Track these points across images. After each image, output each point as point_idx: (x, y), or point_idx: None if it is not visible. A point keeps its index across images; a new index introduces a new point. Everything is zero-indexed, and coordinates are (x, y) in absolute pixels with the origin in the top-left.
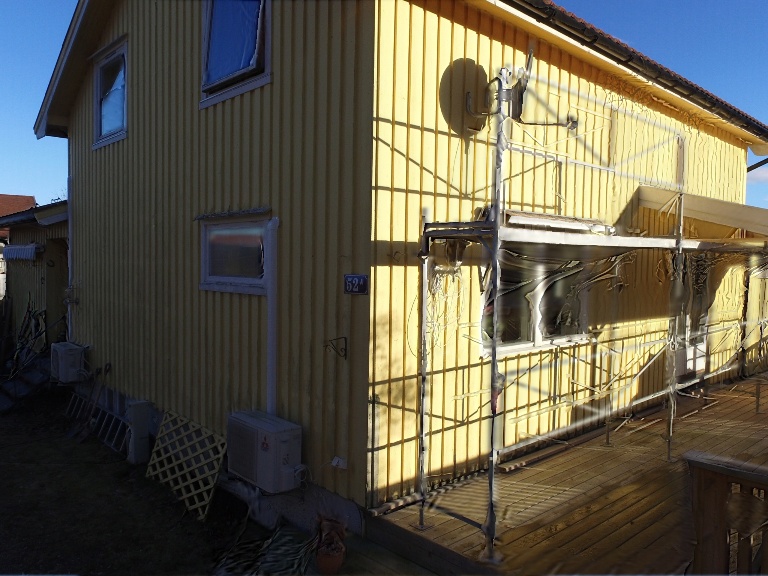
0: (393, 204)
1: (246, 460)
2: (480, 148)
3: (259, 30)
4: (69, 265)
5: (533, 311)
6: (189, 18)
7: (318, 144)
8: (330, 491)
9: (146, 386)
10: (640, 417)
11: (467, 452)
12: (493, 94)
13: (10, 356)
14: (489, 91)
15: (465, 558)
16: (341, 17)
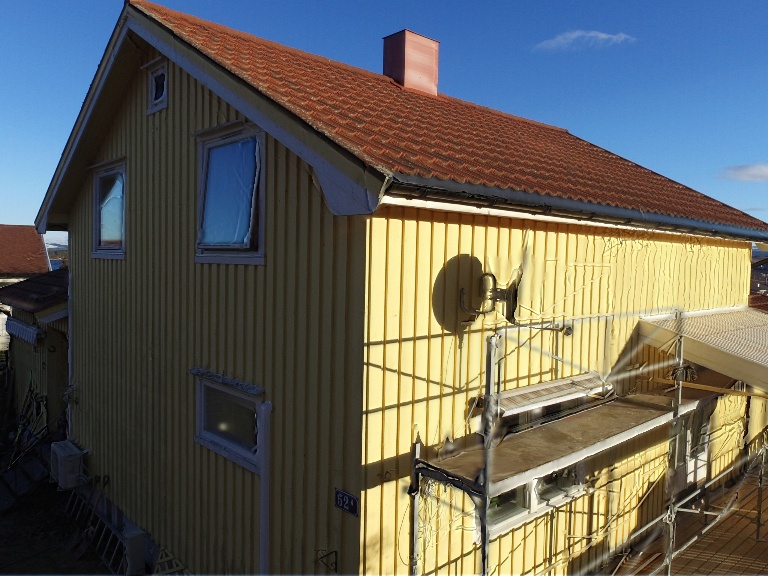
0: (384, 422)
1: None
2: (474, 338)
3: (253, 210)
4: (69, 362)
5: None
6: (185, 167)
7: (310, 346)
8: None
9: (143, 514)
10: (638, 551)
11: None
12: (488, 281)
13: (13, 427)
14: (484, 280)
15: None
16: (333, 230)
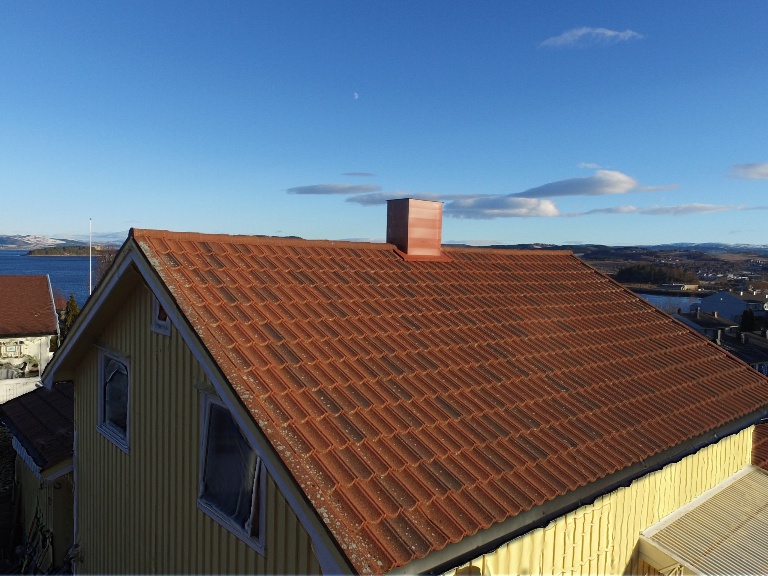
0: None
1: None
2: None
3: (254, 499)
4: (74, 518)
5: None
6: (188, 407)
7: None
8: None
9: None
10: None
11: None
12: None
13: (19, 542)
14: None
15: None
16: None
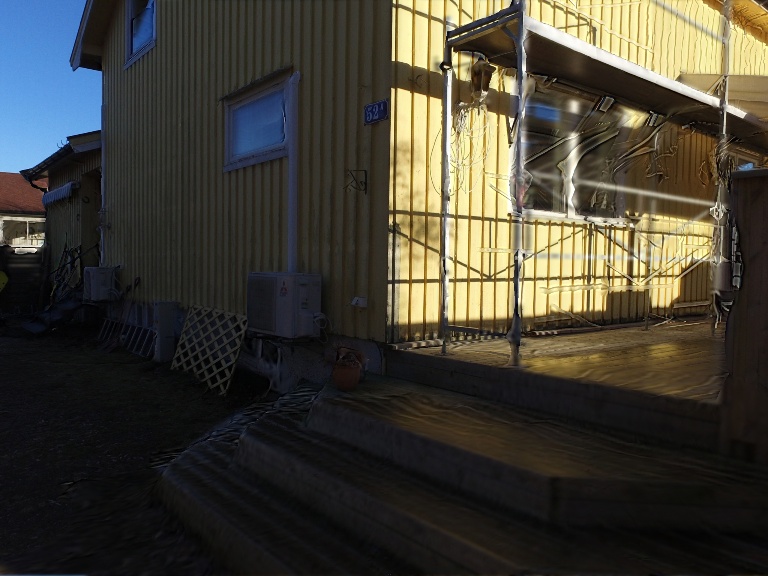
0: (415, 27)
1: (265, 311)
2: None
3: None
4: (102, 192)
5: (565, 181)
6: None
7: None
8: (350, 337)
9: (172, 288)
10: (682, 320)
11: (494, 311)
12: None
13: (48, 301)
14: None
15: (488, 367)
16: None
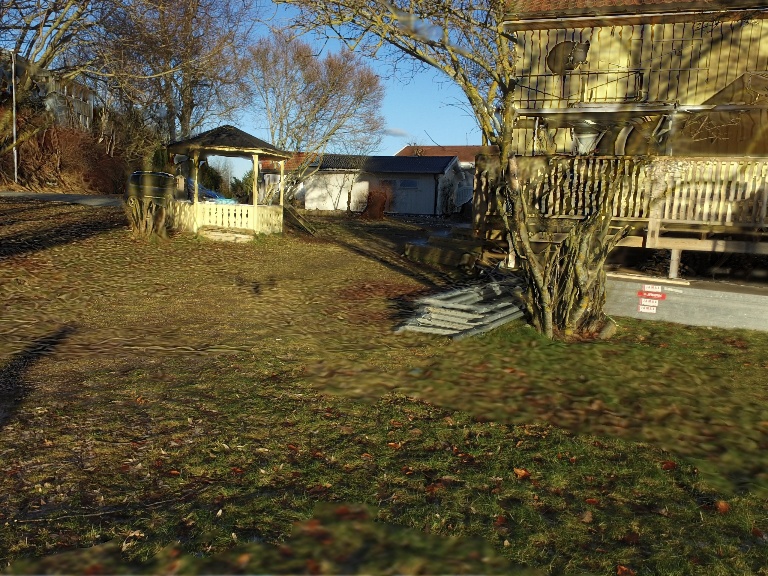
0: None
1: None
2: (574, 77)
3: None
4: None
5: (617, 150)
6: None
7: None
8: None
9: None
10: None
11: None
12: None
13: None
14: None
15: None
16: None
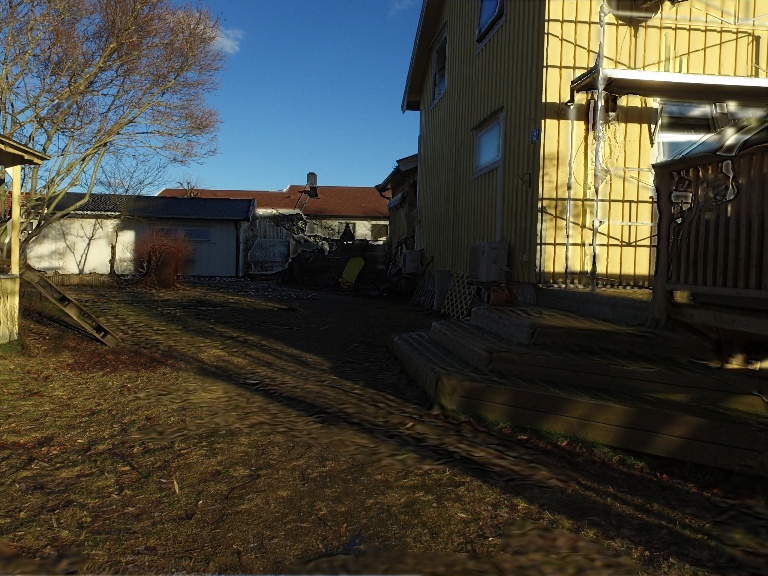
0: (561, 77)
1: (475, 266)
2: (651, 32)
3: None
4: (417, 197)
5: None
6: None
7: (524, 51)
8: (521, 282)
9: (448, 261)
10: None
11: (634, 269)
12: None
13: None
14: None
15: (575, 292)
16: None
